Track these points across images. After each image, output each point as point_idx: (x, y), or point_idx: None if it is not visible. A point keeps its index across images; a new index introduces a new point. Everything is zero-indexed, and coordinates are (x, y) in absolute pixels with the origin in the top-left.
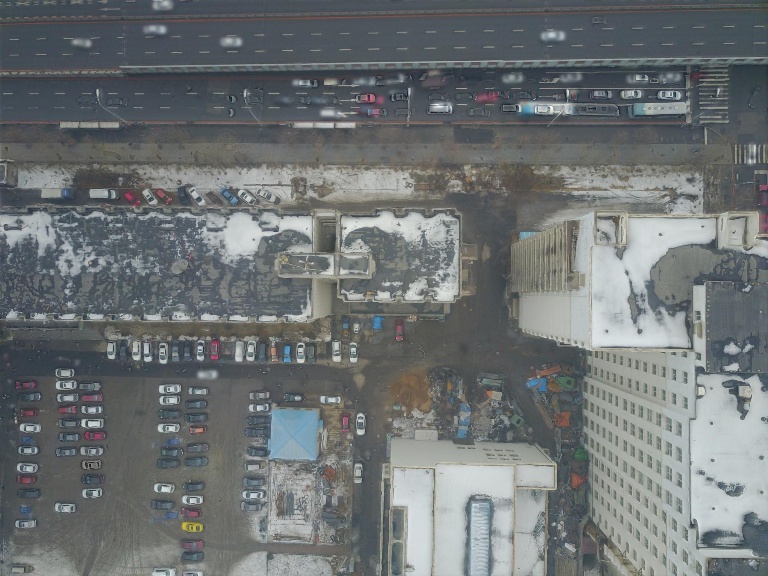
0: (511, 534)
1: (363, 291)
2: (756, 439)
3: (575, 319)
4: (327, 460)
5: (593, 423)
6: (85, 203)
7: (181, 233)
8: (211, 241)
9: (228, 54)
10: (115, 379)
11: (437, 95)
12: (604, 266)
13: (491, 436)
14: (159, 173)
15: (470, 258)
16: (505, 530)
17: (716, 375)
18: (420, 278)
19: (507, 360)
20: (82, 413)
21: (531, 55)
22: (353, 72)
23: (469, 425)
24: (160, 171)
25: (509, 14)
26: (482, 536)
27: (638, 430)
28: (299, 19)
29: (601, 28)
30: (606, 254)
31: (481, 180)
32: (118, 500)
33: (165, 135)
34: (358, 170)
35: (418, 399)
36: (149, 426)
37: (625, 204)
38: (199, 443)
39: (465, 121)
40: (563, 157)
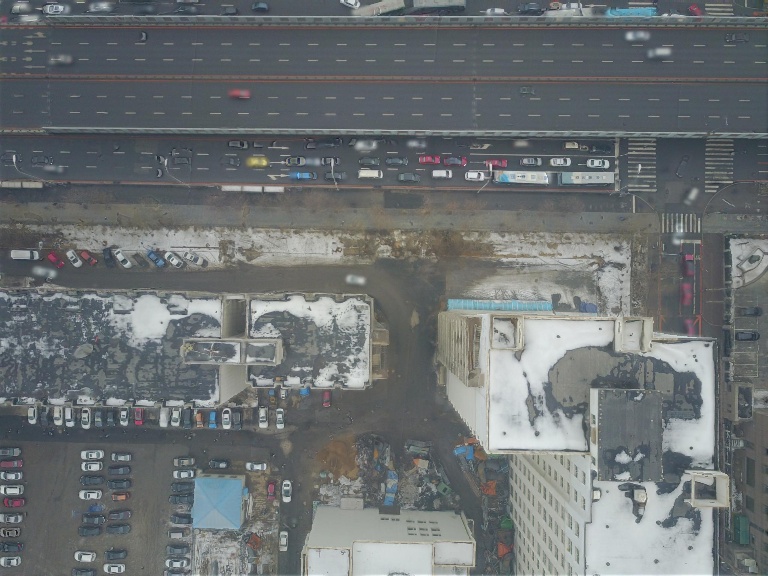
0: None
1: (273, 376)
2: (651, 543)
3: (478, 414)
4: (252, 528)
5: (516, 495)
6: (7, 263)
7: (87, 315)
8: (118, 324)
9: (155, 115)
10: (36, 444)
11: (367, 159)
12: (502, 367)
13: (417, 504)
14: (84, 234)
15: (381, 343)
16: None
17: None
18: (330, 363)
19: (435, 427)
20: (1, 479)
21: (458, 125)
22: (283, 135)
23: (396, 493)
24: (85, 232)
25: (438, 82)
26: None
27: (548, 517)
28: (227, 82)
29: (529, 98)
30: (504, 355)
31: (411, 245)
32: (37, 568)
33: (88, 198)
34: (287, 234)
35: (345, 466)
36: (70, 492)
37: (554, 271)
38: (121, 510)
39: (396, 186)
40: (493, 223)
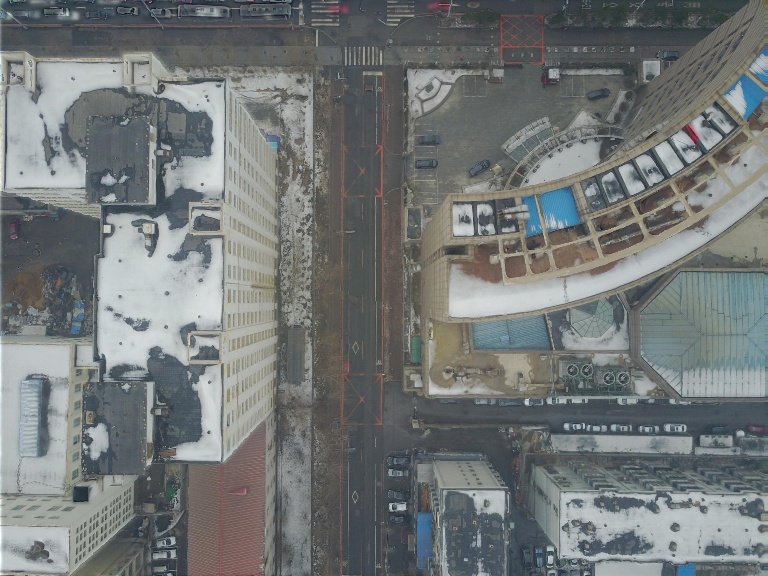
0: (67, 412)
1: None
2: (162, 275)
3: None
4: None
5: None
6: None
7: None
8: None
9: None
10: None
11: None
12: (20, 110)
13: None
14: None
15: None
16: (61, 408)
17: (125, 214)
18: None
19: None
20: None
21: None
22: None
23: (82, 321)
24: None
25: None
26: (31, 413)
27: None
28: None
29: None
30: (22, 98)
31: None
32: None
33: None
34: None
35: (33, 297)
36: None
37: None
38: None
39: (83, 24)
40: (178, 59)
